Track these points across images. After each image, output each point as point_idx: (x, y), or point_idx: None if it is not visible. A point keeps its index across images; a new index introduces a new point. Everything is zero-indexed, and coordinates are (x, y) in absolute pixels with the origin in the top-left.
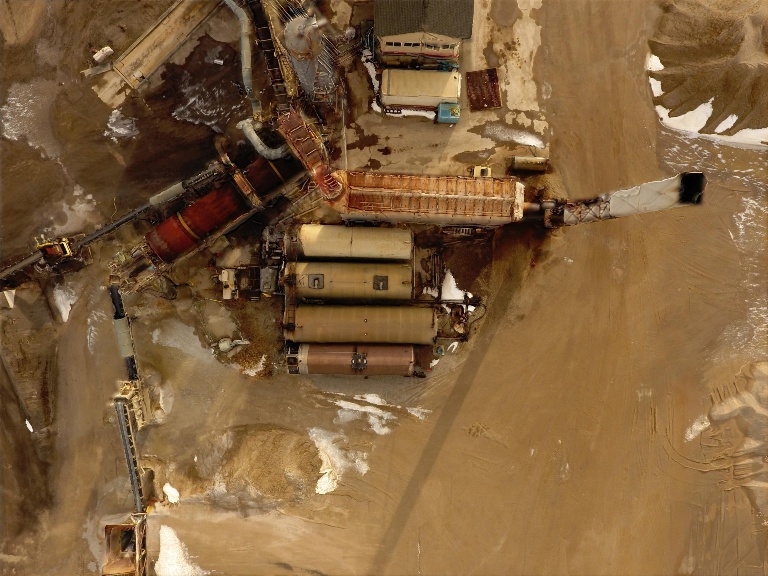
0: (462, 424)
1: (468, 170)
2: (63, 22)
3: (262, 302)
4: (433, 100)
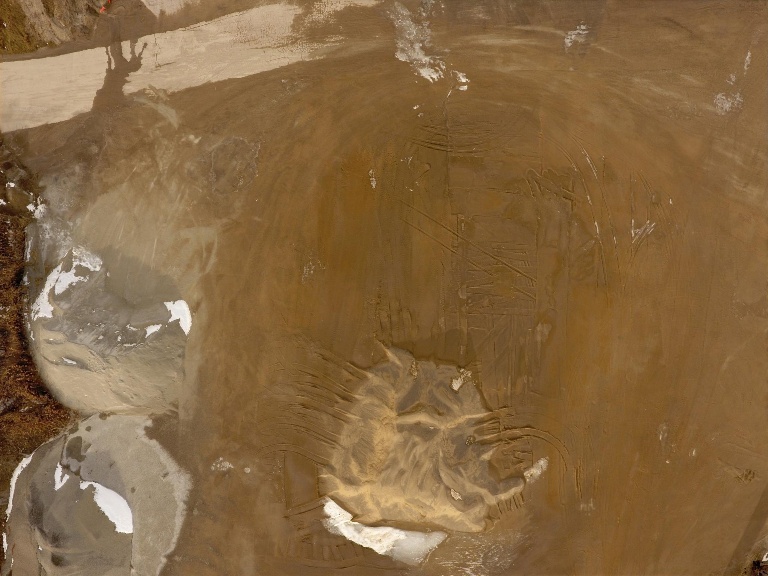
0: (760, 482)
1: None
2: None
3: None
4: None
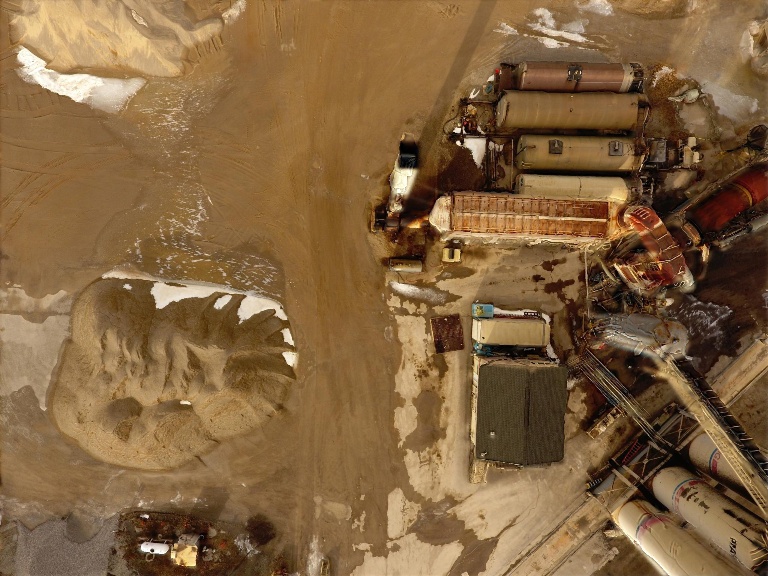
0: (465, 18)
1: (461, 261)
2: None
3: None
4: None
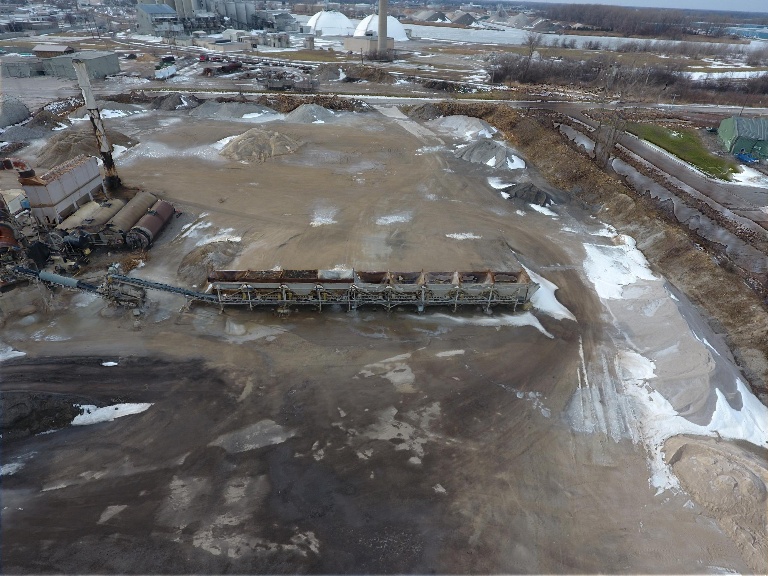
0: None
1: None
2: None
3: None
4: (16, 203)
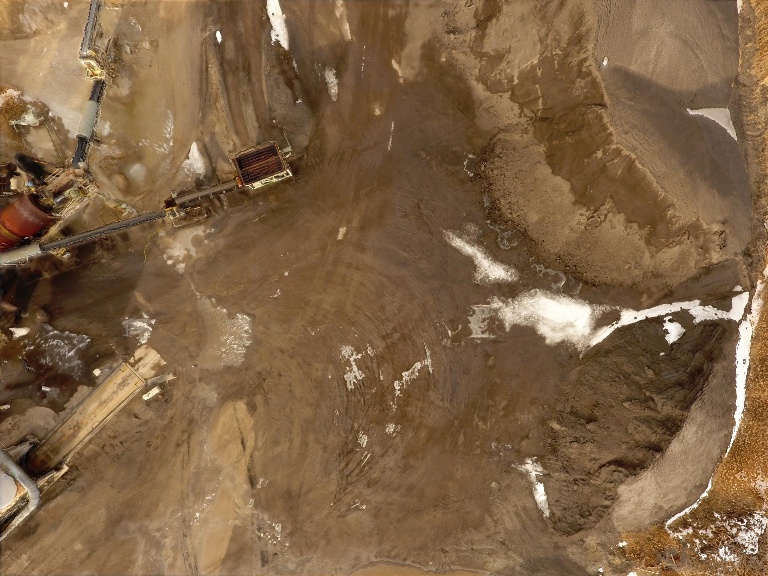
0: None
1: None
2: (192, 422)
3: (1, 162)
4: None
